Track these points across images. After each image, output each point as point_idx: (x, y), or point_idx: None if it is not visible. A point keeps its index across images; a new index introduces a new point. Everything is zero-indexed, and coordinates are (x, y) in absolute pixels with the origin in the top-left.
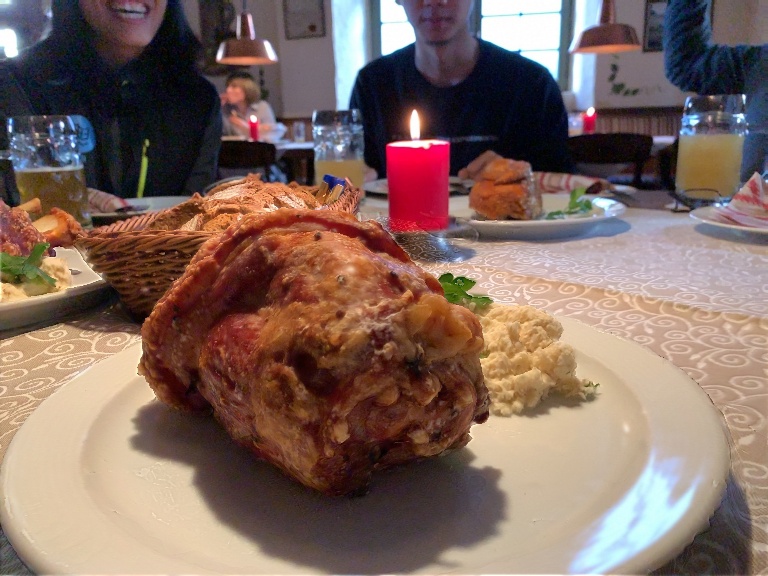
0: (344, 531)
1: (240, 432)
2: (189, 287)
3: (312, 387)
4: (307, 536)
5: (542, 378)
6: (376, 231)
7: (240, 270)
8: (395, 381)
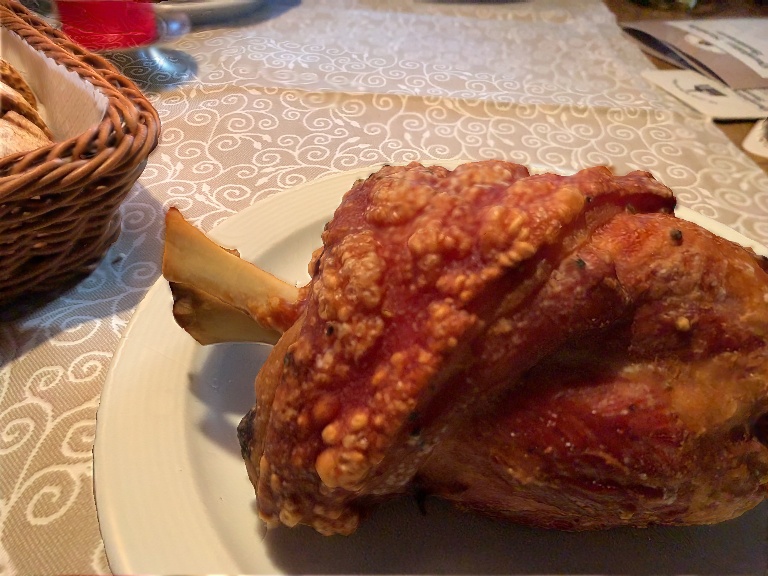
0: (731, 540)
1: (608, 525)
2: (436, 375)
3: None
4: (726, 574)
5: None
6: None
7: (575, 326)
8: None
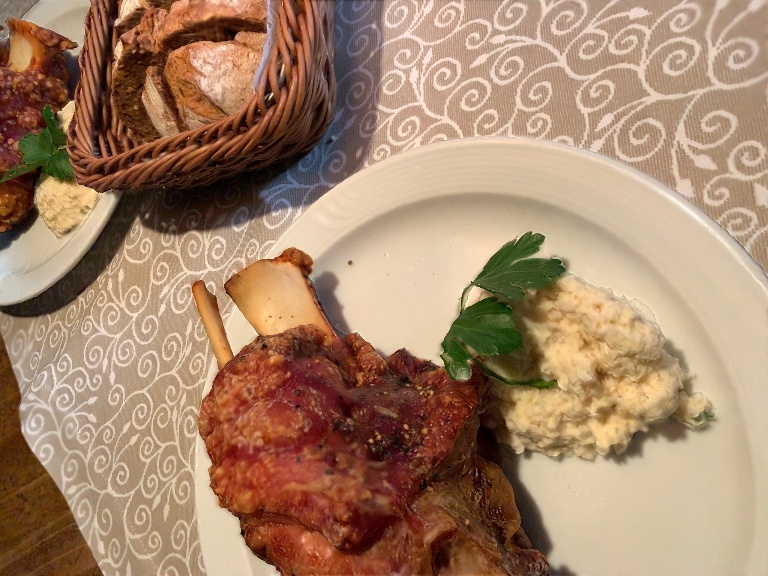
0: None
1: None
2: None
3: None
4: None
5: (629, 428)
6: (349, 539)
7: None
8: None
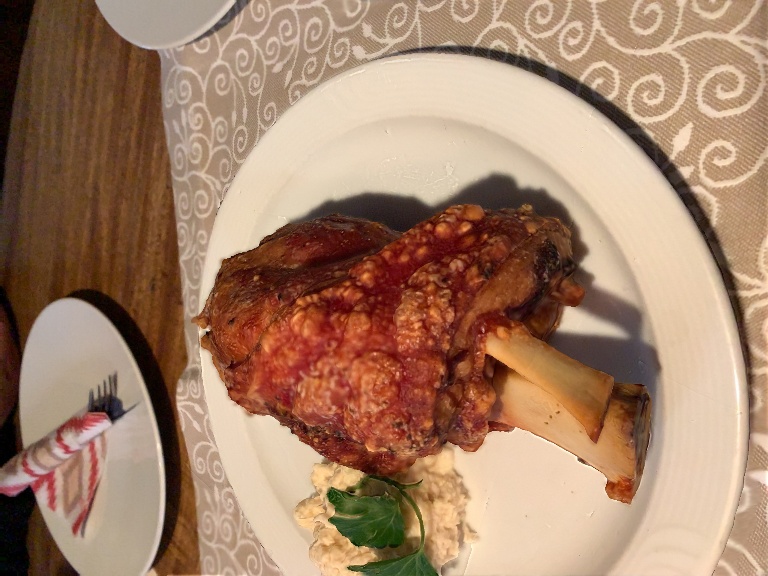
0: None
1: None
2: None
3: None
4: None
5: None
6: None
7: (302, 270)
8: None
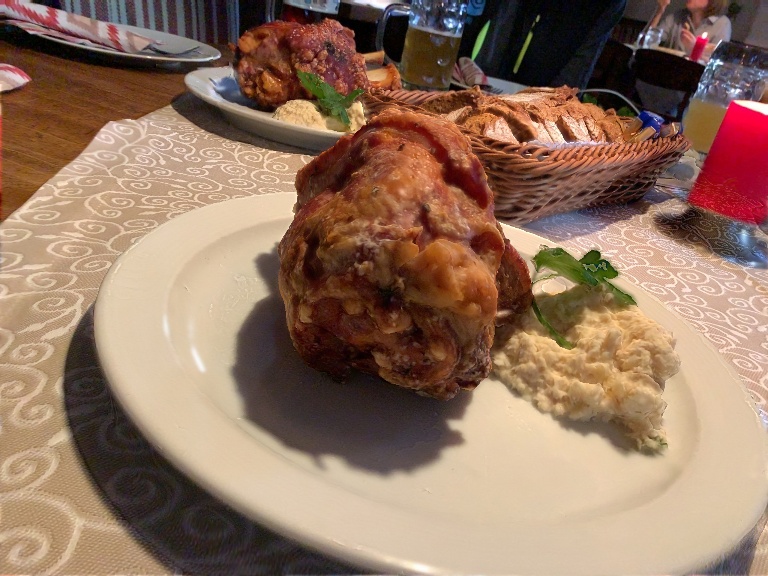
0: (293, 393)
1: None
2: (328, 154)
3: (308, 268)
4: (268, 379)
5: (603, 399)
6: (463, 165)
7: (347, 153)
8: (359, 297)
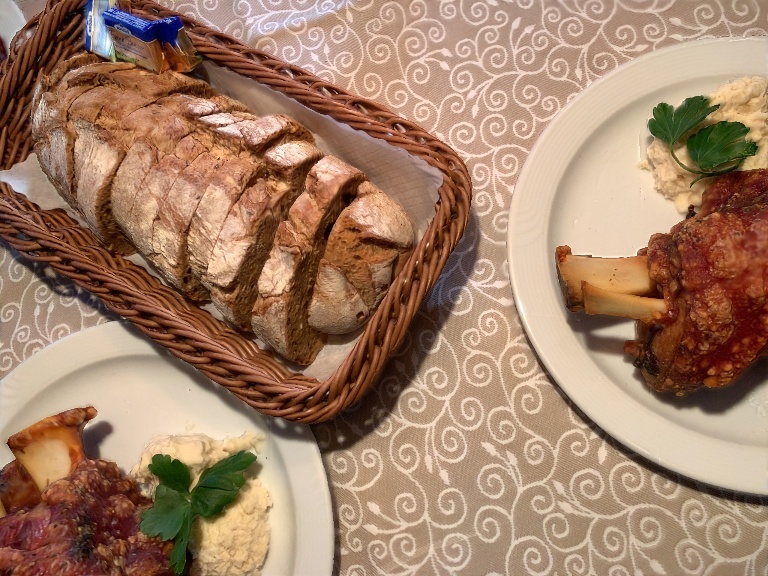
0: None
1: None
2: None
3: None
4: None
5: None
6: None
7: None
8: None
